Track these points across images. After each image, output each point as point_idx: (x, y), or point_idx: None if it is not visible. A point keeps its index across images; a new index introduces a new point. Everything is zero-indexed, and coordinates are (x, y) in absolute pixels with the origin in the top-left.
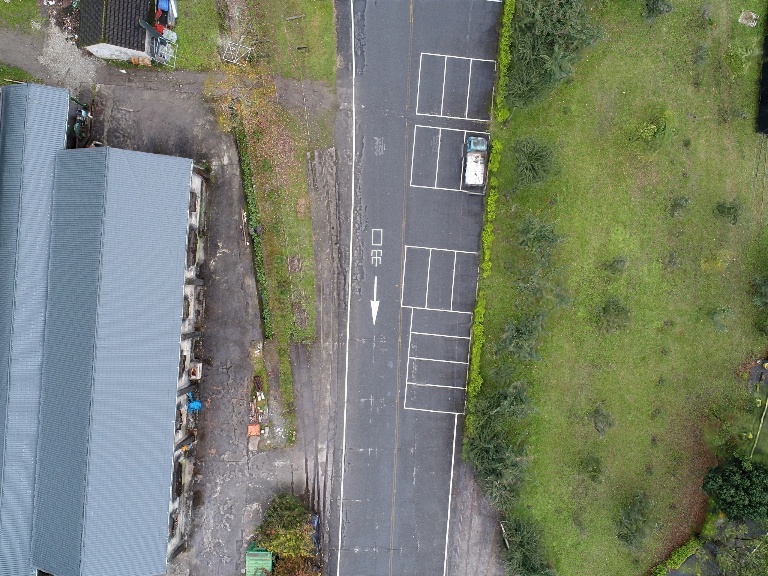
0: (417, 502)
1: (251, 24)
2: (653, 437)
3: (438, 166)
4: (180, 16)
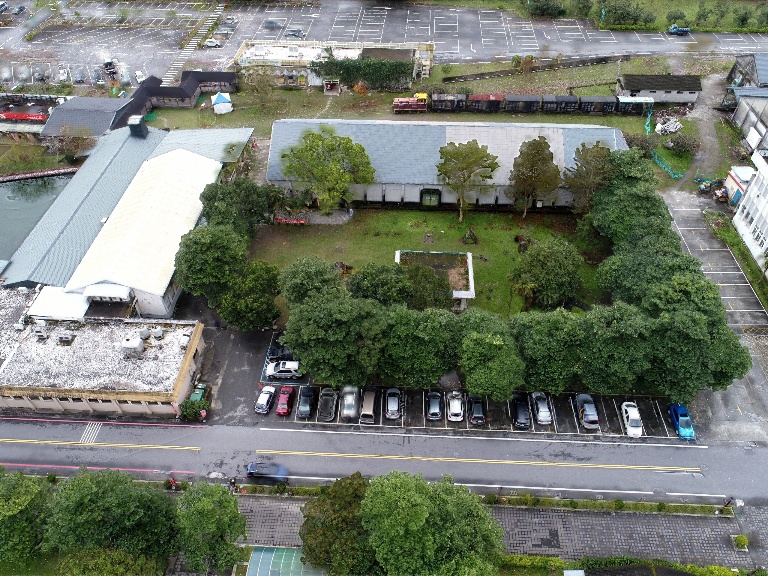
0: None
1: None
2: (754, 6)
3: None
4: None
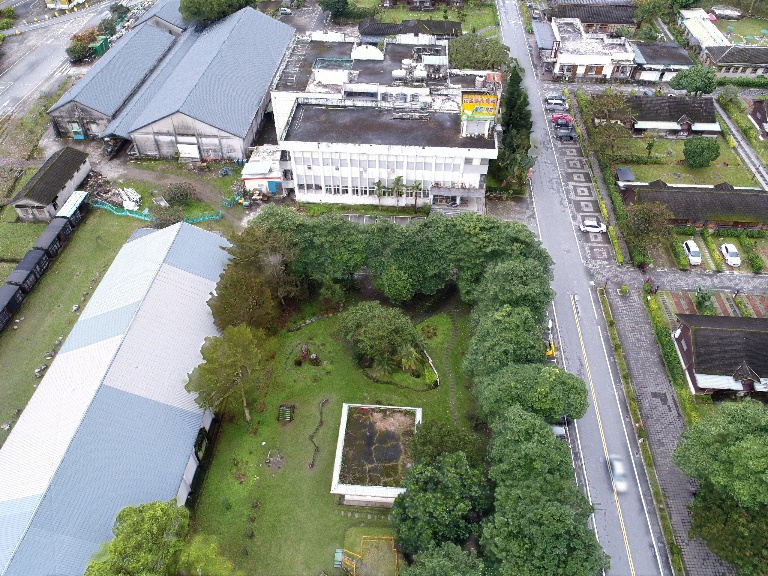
0: None
1: (1, 184)
2: None
3: None
4: None
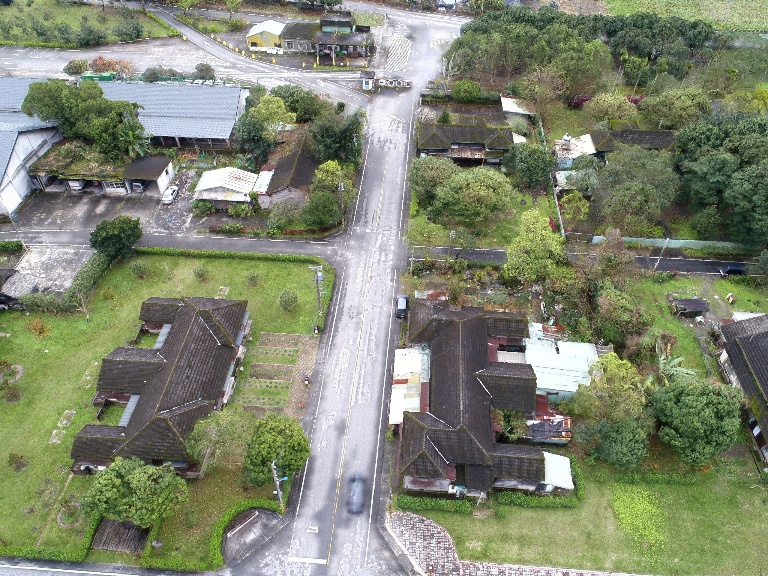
0: None
1: None
2: None
3: None
4: None
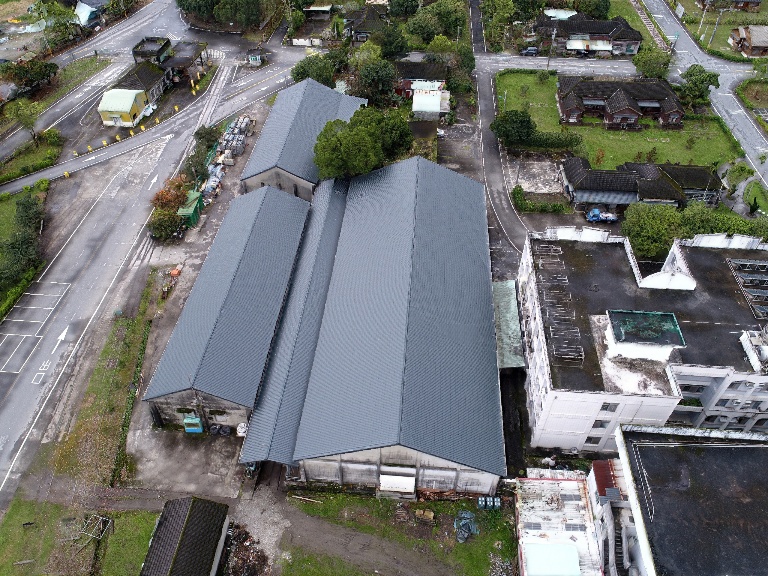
0: (87, 243)
1: None
2: None
3: None
4: (140, 565)
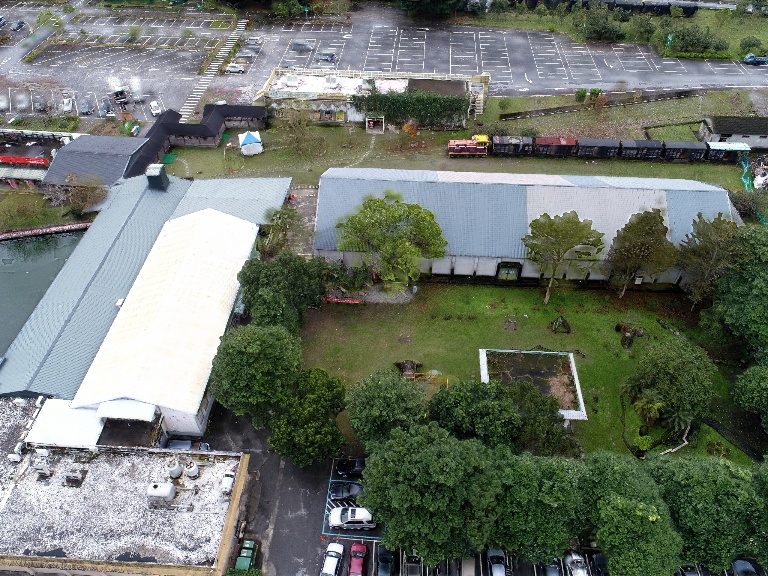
0: None
1: None
2: None
3: (763, 69)
4: None
